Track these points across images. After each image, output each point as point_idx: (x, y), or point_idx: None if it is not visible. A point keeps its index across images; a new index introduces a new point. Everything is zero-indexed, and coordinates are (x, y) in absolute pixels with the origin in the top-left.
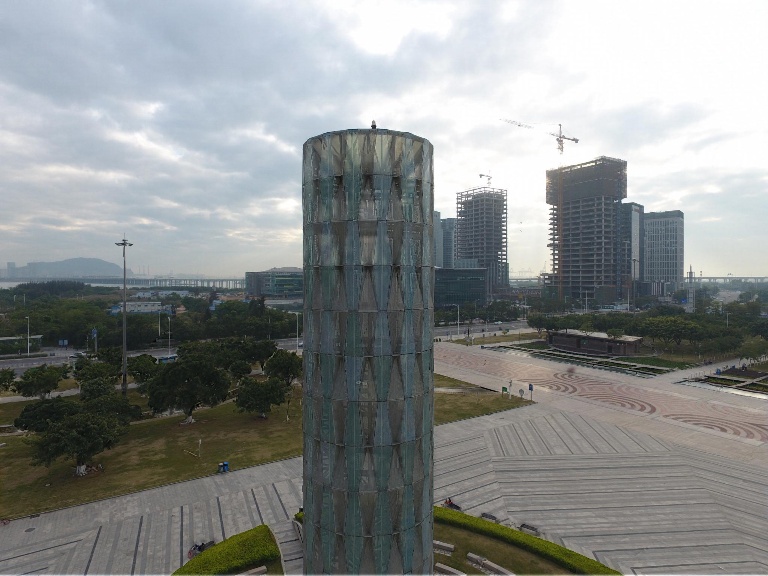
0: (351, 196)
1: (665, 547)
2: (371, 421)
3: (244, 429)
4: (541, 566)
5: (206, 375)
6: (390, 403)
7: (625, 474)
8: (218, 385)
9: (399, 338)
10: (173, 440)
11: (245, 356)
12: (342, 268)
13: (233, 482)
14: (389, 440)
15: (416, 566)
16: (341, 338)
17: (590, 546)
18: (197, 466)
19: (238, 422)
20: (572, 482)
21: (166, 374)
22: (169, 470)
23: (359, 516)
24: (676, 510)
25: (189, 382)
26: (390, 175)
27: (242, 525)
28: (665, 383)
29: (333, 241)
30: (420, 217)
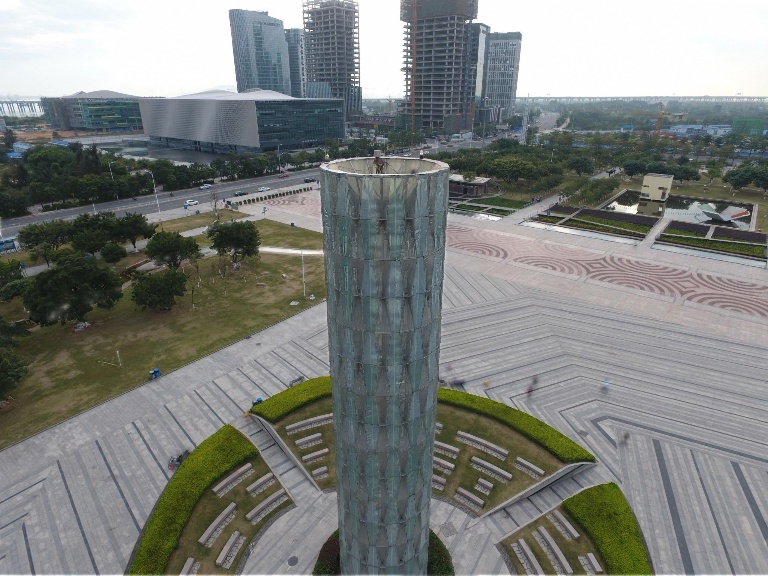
0: (393, 238)
1: (528, 377)
2: (407, 406)
3: (152, 326)
4: (458, 414)
5: (92, 278)
6: (420, 390)
7: (495, 320)
8: (110, 286)
9: (427, 344)
10: (78, 351)
11: (111, 235)
12: (386, 300)
13: (172, 387)
14: (419, 414)
15: (429, 478)
16: (383, 352)
17: (482, 387)
18: (124, 377)
19: (140, 318)
20: (460, 334)
21: (44, 285)
22: (95, 387)
23: (398, 465)
24: (531, 346)
25: (77, 290)
26: (428, 216)
27: (204, 428)
28: (511, 225)
29: (376, 277)
30: (442, 241)
